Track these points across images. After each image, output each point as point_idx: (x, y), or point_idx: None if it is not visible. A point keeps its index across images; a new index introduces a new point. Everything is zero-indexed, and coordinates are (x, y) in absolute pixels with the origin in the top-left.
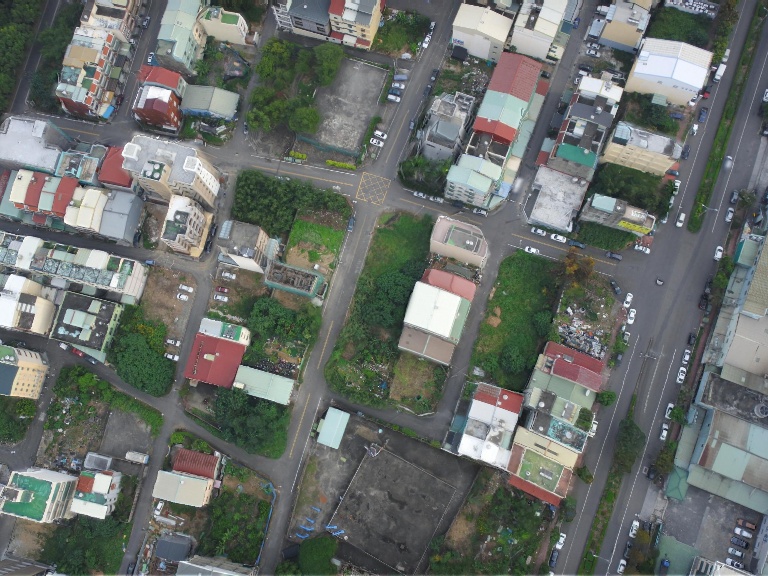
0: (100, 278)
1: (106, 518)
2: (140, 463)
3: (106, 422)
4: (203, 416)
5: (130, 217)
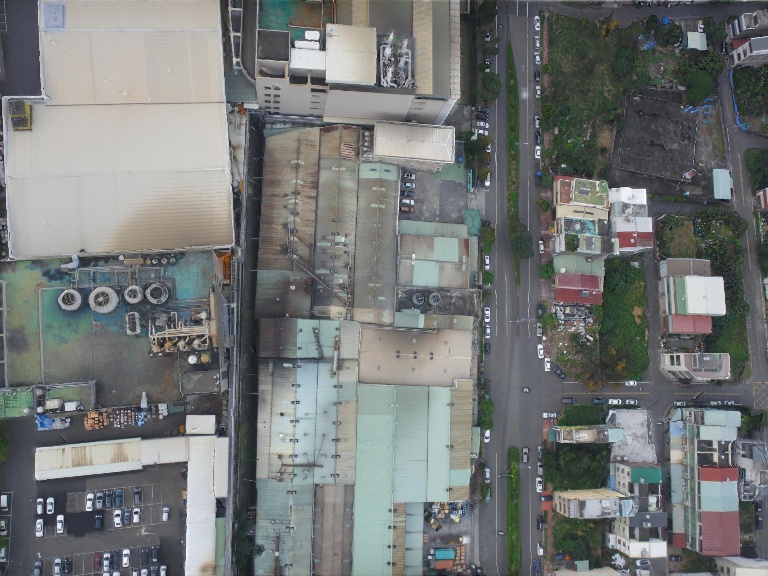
0: None
1: None
2: None
3: None
4: None
5: None
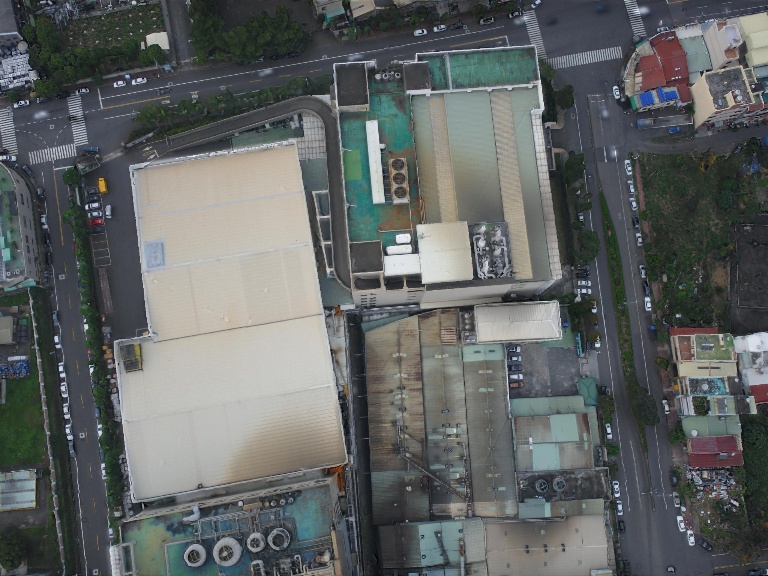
0: None
1: None
2: None
3: None
4: None
5: None
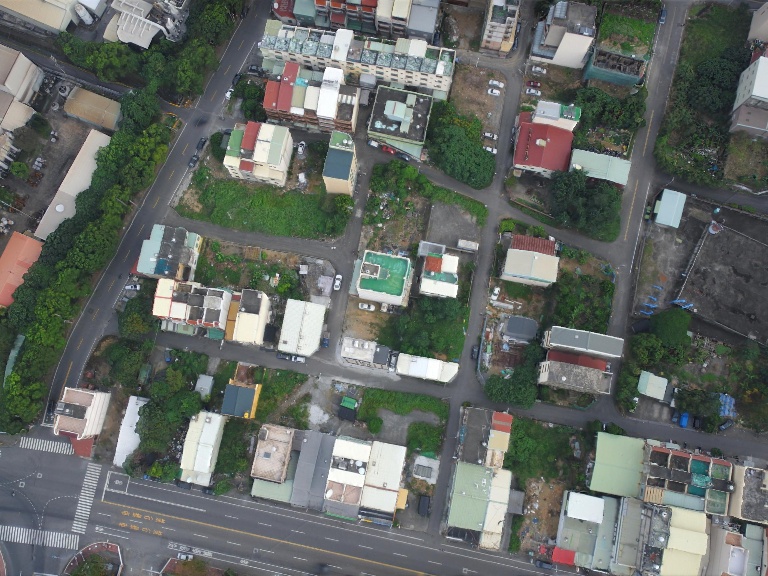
0: (424, 66)
1: (454, 298)
2: (472, 251)
3: (425, 217)
4: (529, 205)
5: (437, 12)
